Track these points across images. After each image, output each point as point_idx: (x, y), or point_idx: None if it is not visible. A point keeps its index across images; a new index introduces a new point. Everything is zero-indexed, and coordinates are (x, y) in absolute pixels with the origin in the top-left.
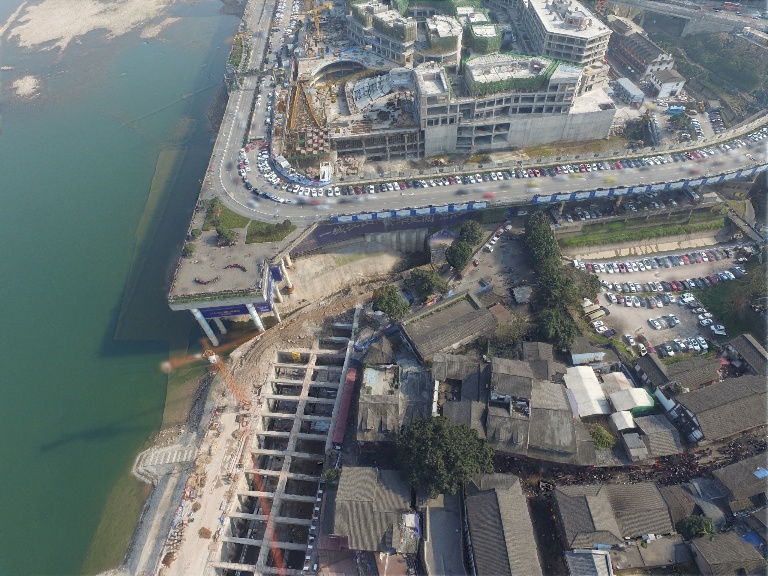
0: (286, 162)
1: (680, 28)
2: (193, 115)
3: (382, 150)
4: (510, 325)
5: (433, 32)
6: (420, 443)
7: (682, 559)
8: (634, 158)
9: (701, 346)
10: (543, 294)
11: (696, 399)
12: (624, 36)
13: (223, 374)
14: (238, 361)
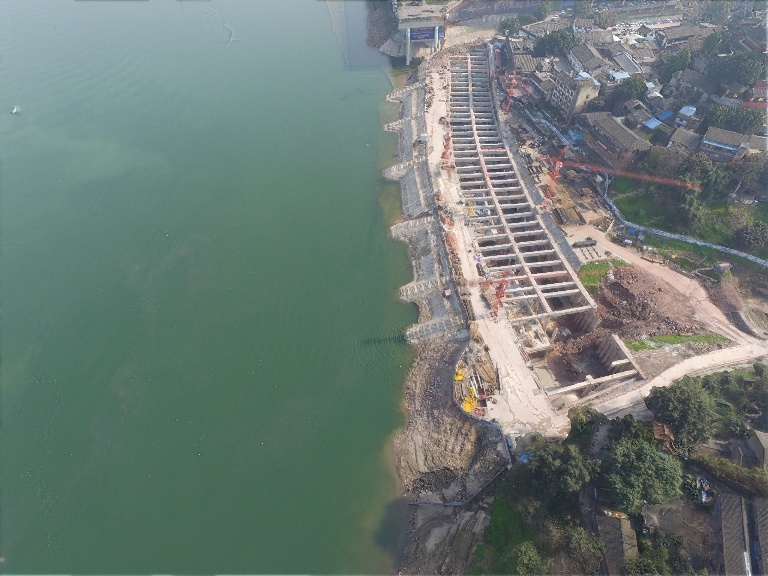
0: None
1: None
2: None
3: None
4: None
5: None
6: None
7: (658, 61)
8: None
9: None
10: None
11: None
12: None
13: (423, 64)
14: (430, 60)
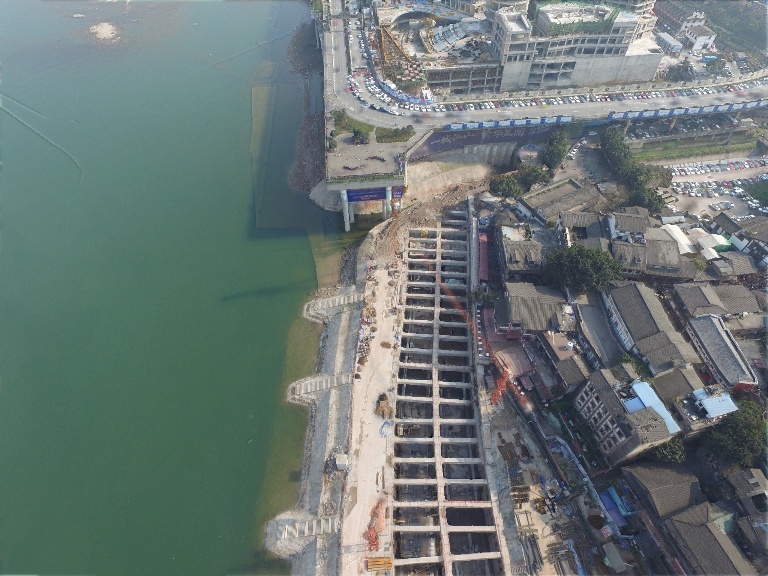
0: (394, 85)
1: None
2: (273, 59)
3: (465, 83)
4: (606, 202)
5: None
6: (570, 259)
7: None
8: (684, 89)
9: None
10: (630, 180)
11: (765, 235)
12: None
13: (367, 245)
14: (377, 236)
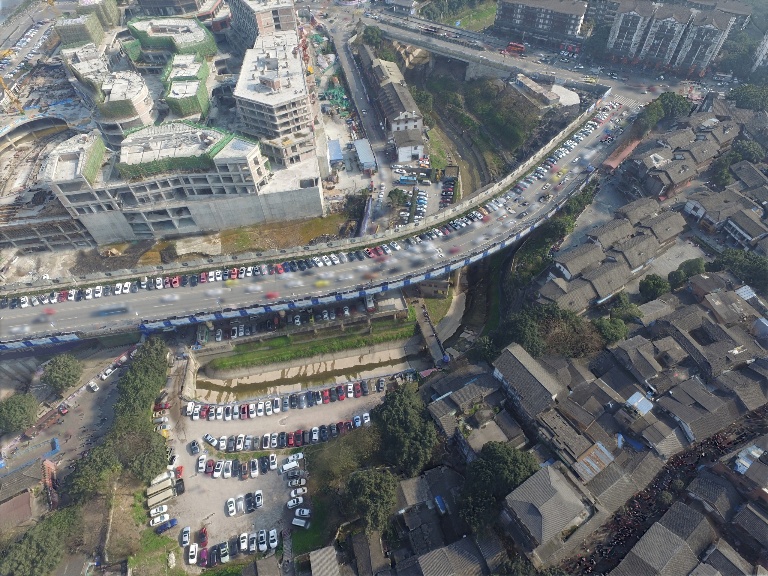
0: None
1: (465, 71)
2: None
3: (38, 240)
4: (9, 534)
5: (109, 93)
6: None
7: None
8: (304, 257)
9: (268, 544)
10: (68, 483)
11: None
12: (380, 86)
13: None
14: None
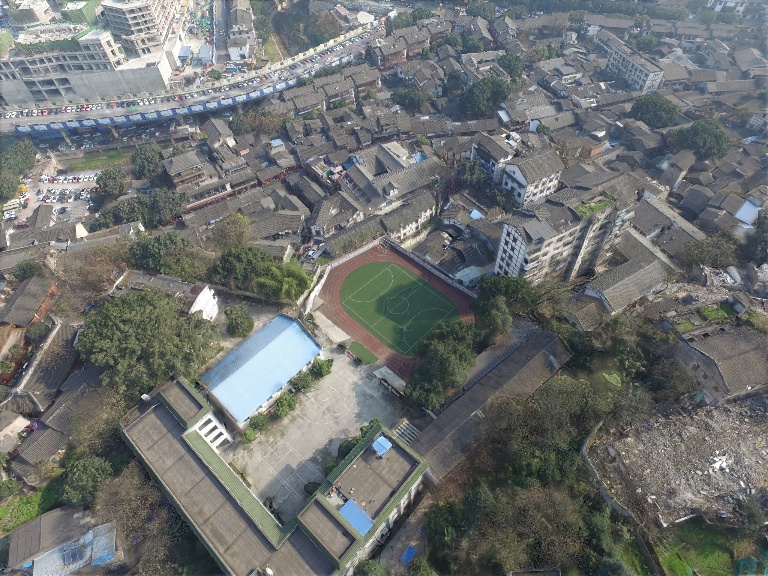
0: None
1: None
2: None
3: None
4: None
5: None
6: None
7: None
8: None
9: None
10: None
11: None
12: None
13: None
14: None
